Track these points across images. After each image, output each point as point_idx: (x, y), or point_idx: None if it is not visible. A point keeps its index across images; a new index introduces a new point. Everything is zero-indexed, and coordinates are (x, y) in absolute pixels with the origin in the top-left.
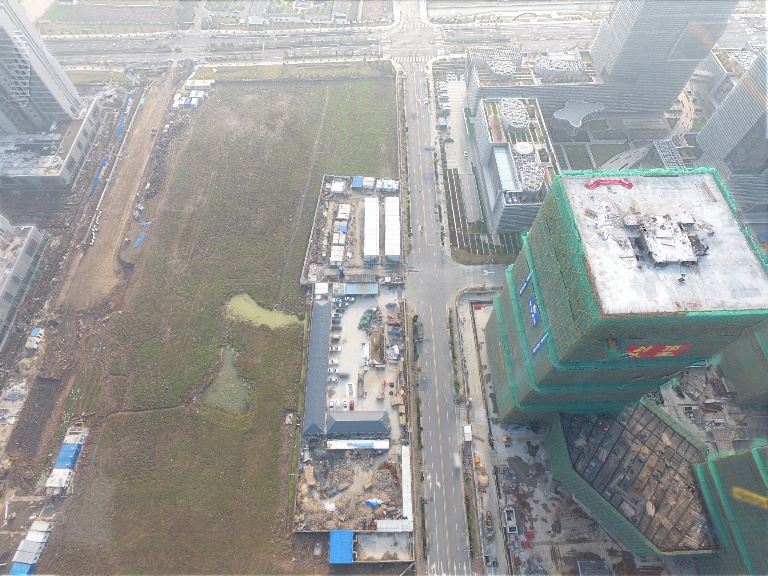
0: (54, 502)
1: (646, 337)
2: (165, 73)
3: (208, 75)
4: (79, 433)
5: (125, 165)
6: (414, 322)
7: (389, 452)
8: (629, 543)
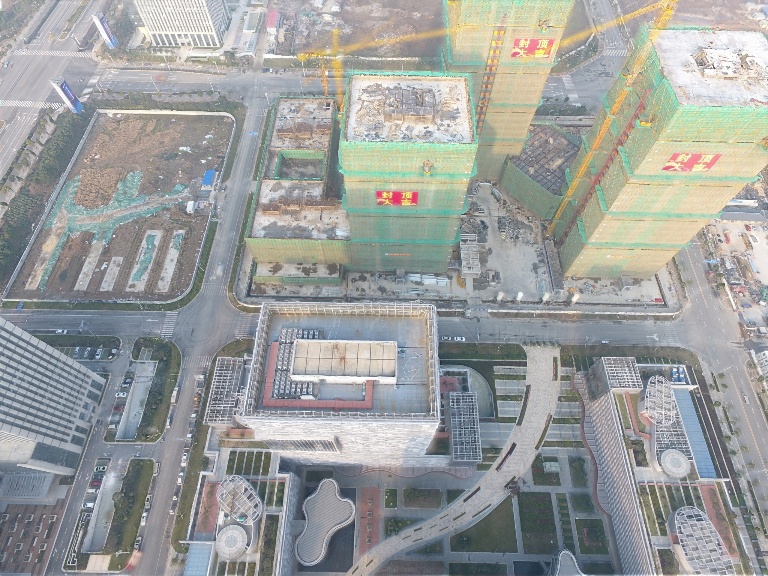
0: None
1: None
2: None
3: None
4: None
5: None
6: None
7: None
8: None
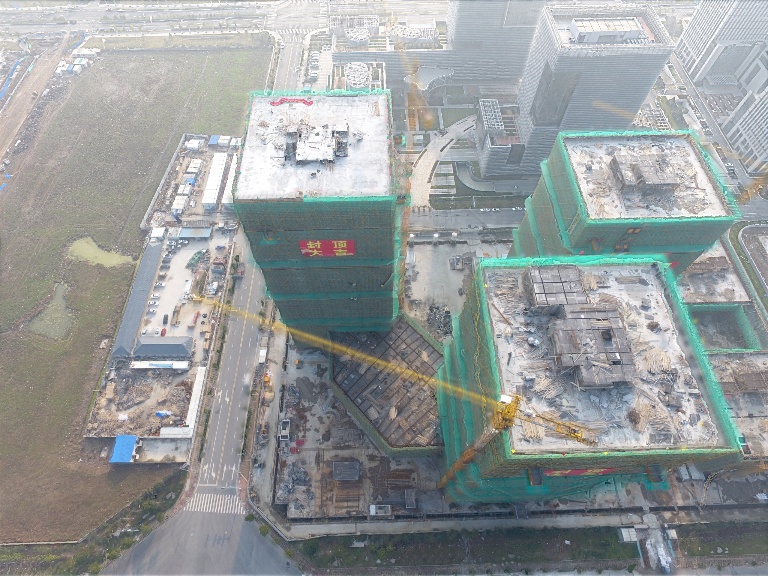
0: None
1: (300, 229)
2: (57, 43)
3: (95, 44)
4: None
5: (2, 125)
6: (236, 261)
7: (189, 372)
8: (382, 447)
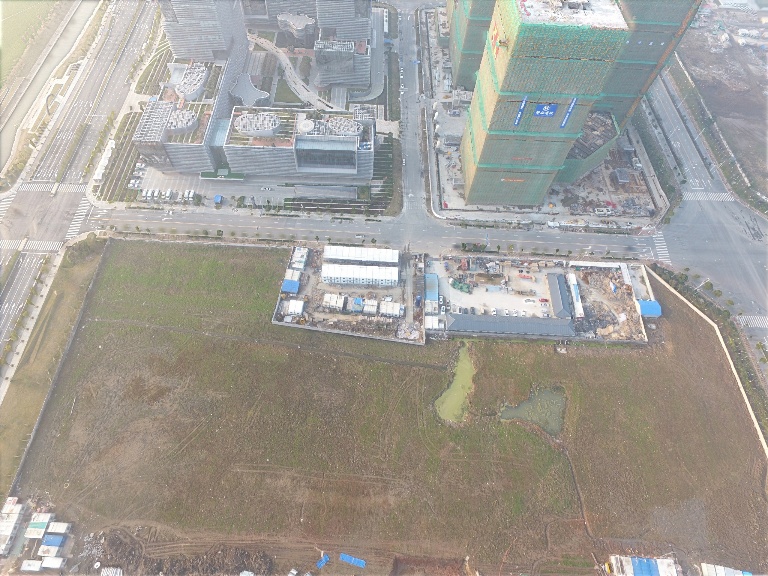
0: (685, 571)
1: None
2: None
3: None
4: (621, 560)
5: None
6: None
7: None
8: None
